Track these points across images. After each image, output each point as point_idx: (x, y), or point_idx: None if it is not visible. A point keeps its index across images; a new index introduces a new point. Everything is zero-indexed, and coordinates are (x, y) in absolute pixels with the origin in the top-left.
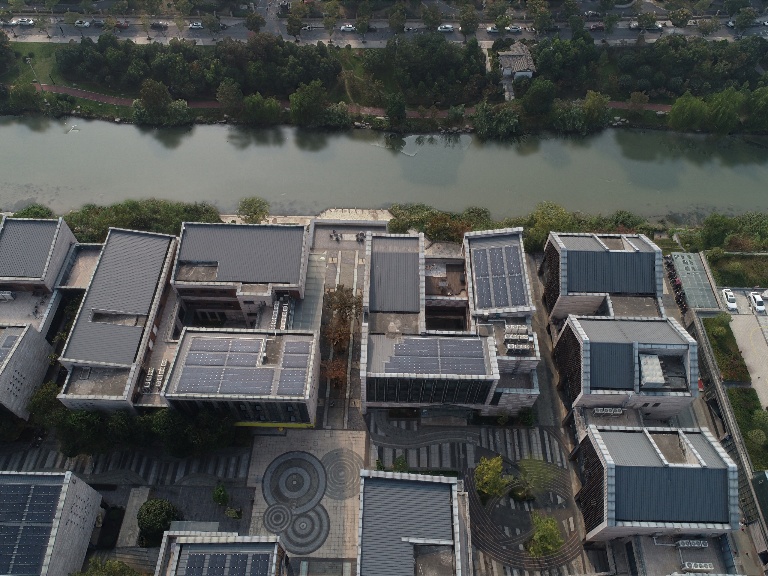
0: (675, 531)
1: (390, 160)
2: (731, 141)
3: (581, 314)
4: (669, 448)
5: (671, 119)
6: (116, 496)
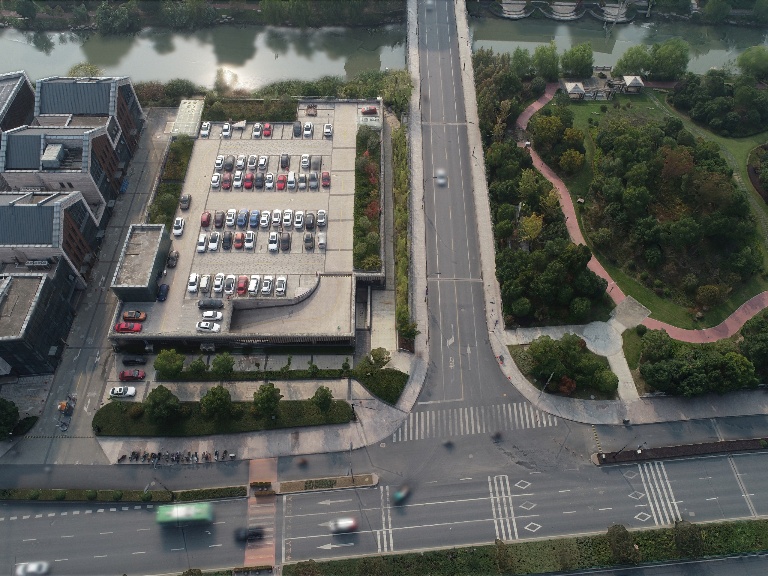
0: (23, 255)
1: (16, 50)
2: (314, 32)
3: None
4: None
5: None
6: None
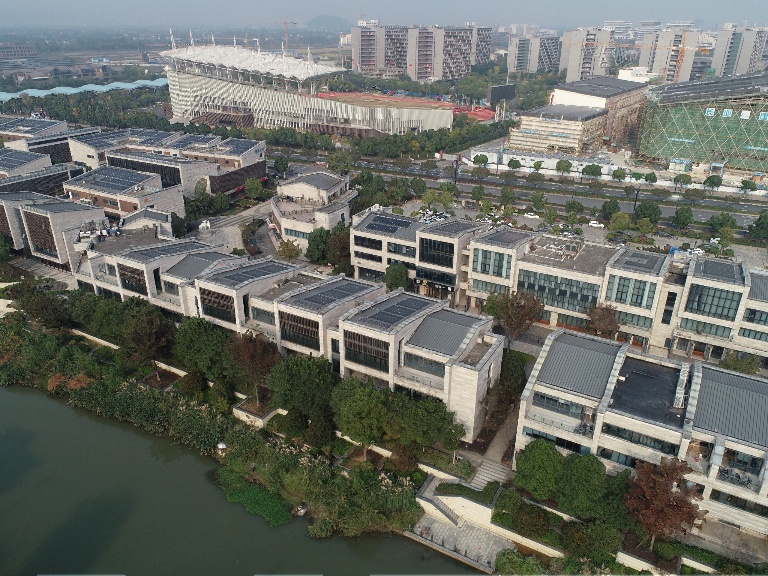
0: None
1: None
2: None
3: None
4: None
5: None
6: None
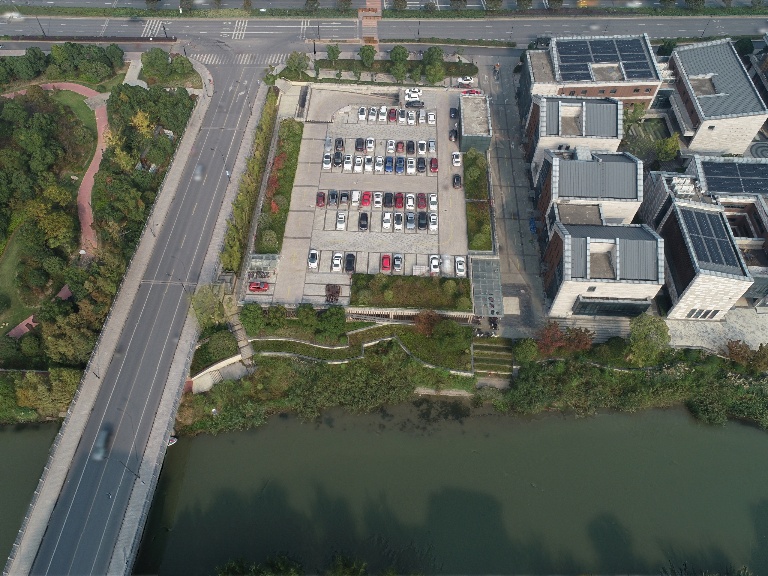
0: None
1: None
2: (326, 569)
3: None
4: (568, 128)
5: None
6: None
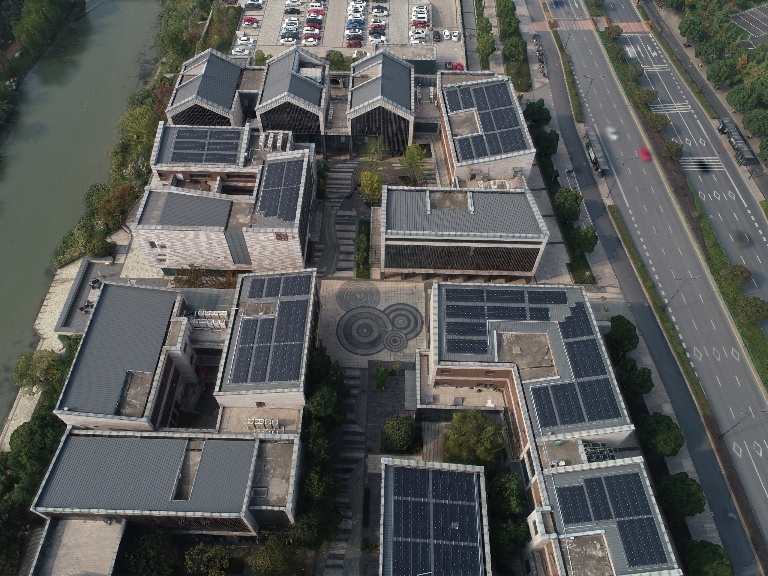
0: None
1: None
2: (70, 28)
3: (241, 122)
4: None
5: (31, 49)
6: (375, 487)
